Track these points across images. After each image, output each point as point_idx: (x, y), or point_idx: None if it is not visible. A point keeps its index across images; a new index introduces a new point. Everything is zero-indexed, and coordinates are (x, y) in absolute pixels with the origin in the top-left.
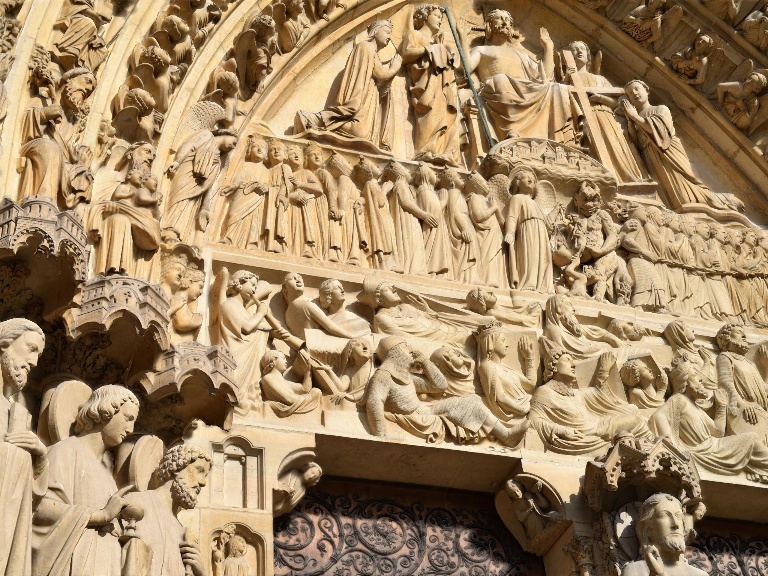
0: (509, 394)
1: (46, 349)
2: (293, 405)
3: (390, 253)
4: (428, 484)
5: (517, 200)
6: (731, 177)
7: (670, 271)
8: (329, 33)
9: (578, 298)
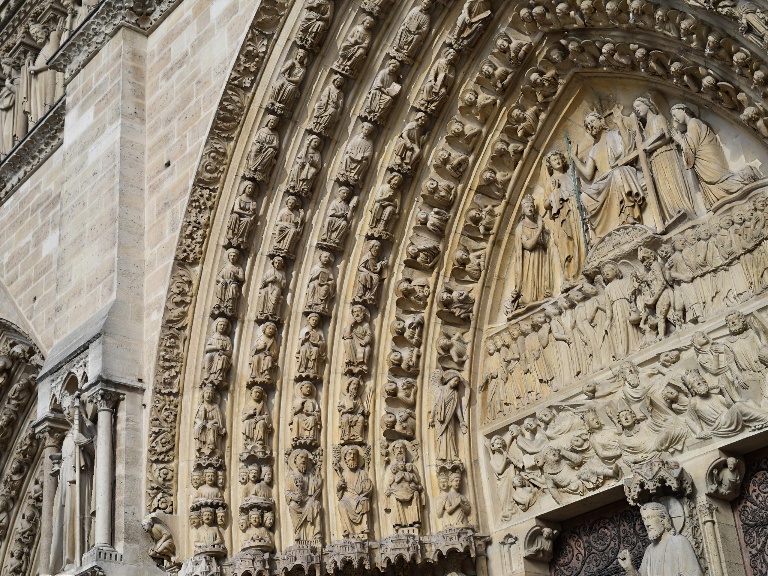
0: (608, 449)
1: (392, 569)
2: (525, 505)
3: (553, 378)
4: (614, 501)
5: (605, 293)
6: (755, 140)
7: (703, 280)
8: (505, 230)
9: (645, 347)
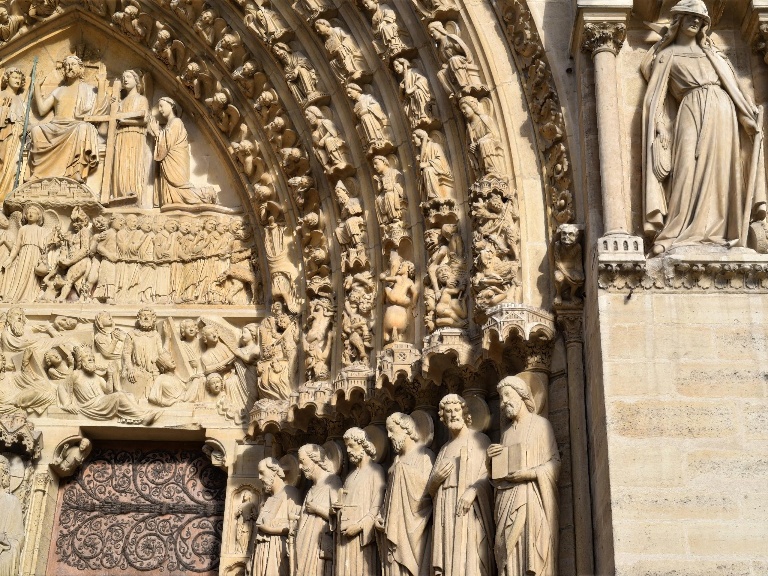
0: None
1: None
2: None
3: None
4: None
5: (20, 232)
6: (226, 168)
7: (127, 266)
8: None
9: (41, 302)
